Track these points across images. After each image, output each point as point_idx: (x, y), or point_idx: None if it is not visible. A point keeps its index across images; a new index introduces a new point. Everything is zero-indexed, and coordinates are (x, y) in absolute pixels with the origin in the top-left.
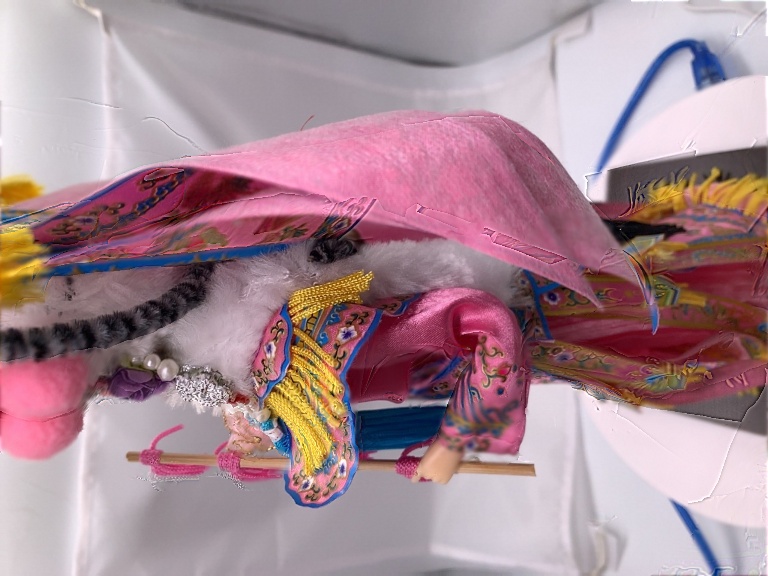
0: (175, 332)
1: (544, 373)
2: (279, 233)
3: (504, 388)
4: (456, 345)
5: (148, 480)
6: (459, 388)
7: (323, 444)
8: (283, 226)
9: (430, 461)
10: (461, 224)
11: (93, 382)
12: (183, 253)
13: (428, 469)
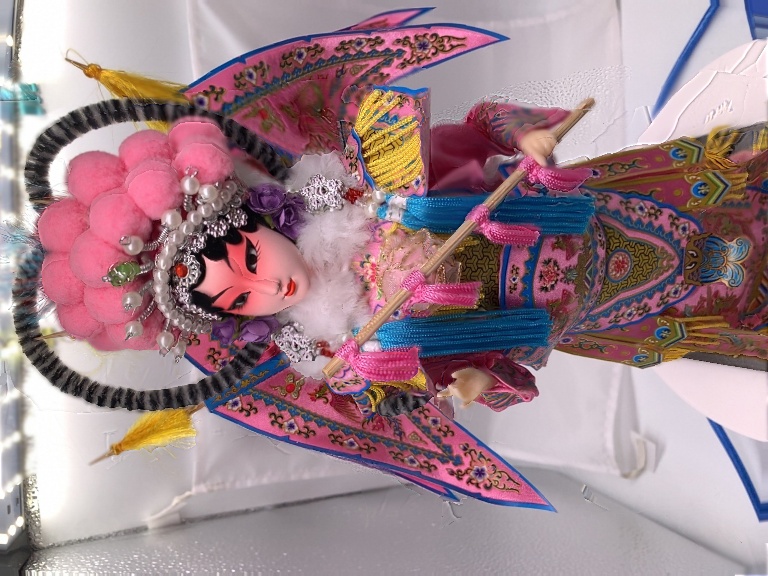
0: (285, 186)
1: (620, 197)
2: (320, 148)
3: (508, 99)
4: (468, 127)
5: (345, 344)
6: (495, 130)
7: (414, 135)
8: (315, 133)
9: (525, 142)
10: (646, 506)
11: (235, 170)
12: (265, 140)
13: (529, 143)
